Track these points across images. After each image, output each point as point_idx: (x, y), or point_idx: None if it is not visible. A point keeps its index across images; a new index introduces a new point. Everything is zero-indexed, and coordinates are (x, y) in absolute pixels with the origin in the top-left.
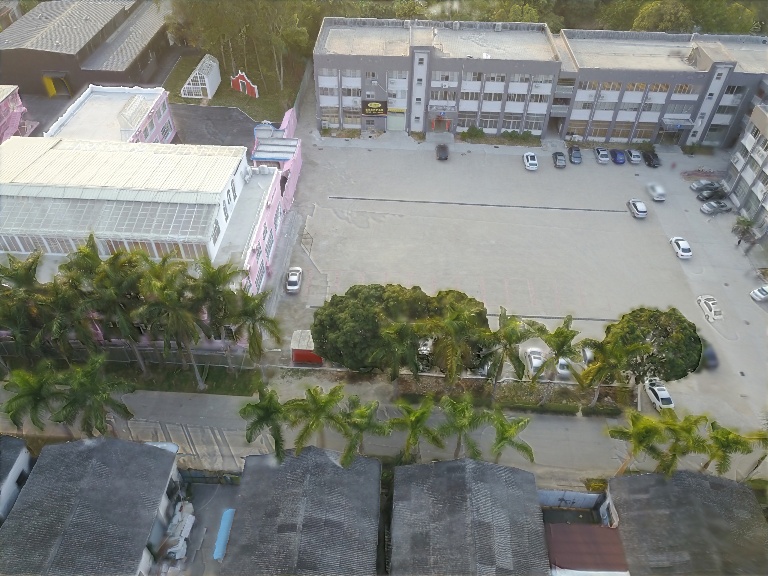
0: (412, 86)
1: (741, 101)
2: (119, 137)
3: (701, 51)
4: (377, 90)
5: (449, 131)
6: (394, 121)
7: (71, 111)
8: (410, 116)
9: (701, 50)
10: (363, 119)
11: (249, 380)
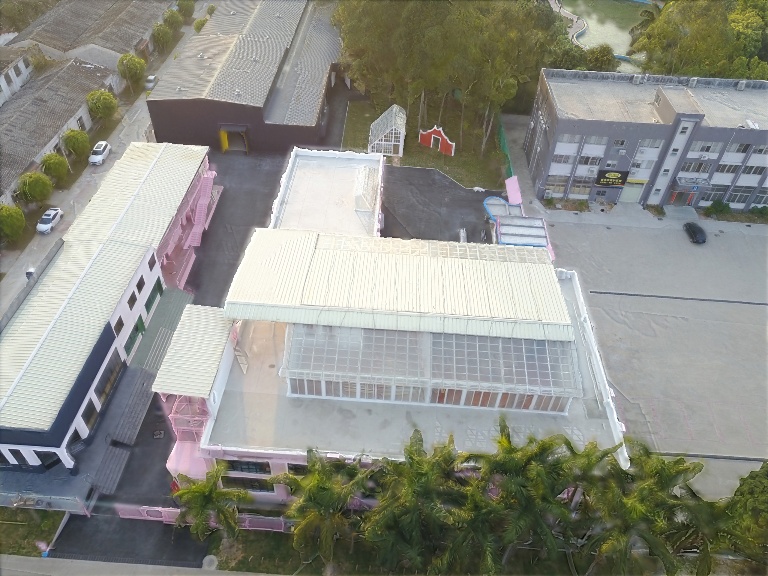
0: (665, 157)
1: None
2: (358, 221)
3: None
4: (621, 159)
5: (689, 204)
6: (628, 192)
7: (285, 183)
8: (651, 188)
9: None
10: (594, 189)
11: (630, 575)
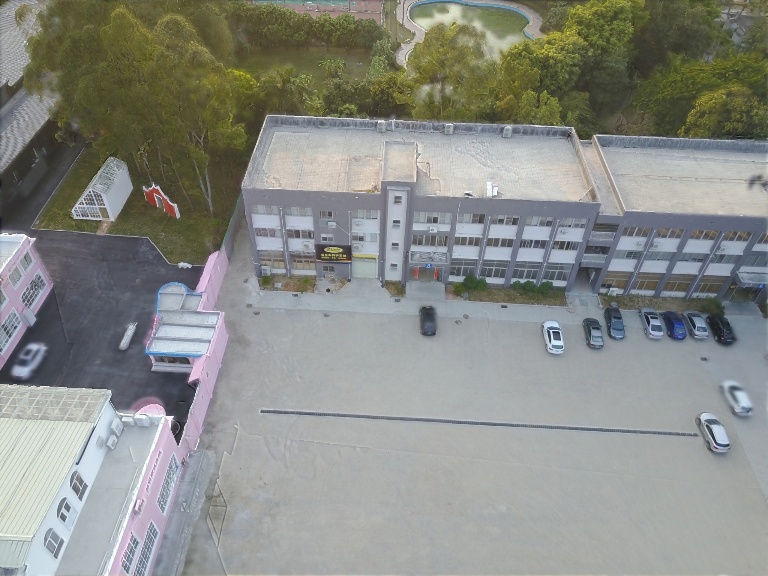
0: (386, 229)
1: None
2: None
3: None
4: (336, 232)
5: (438, 280)
6: (362, 267)
7: None
8: (384, 264)
9: None
10: (318, 265)
11: None
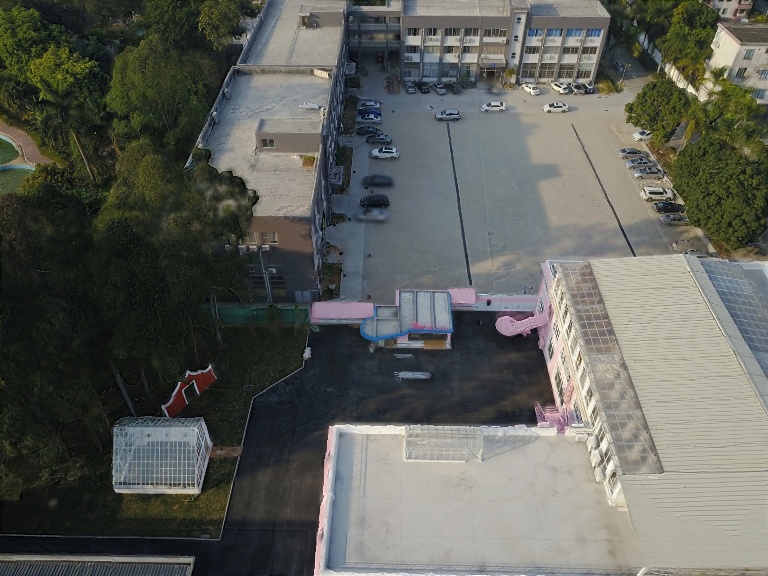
0: (327, 173)
1: (347, 32)
2: (506, 455)
3: (317, 13)
4: None
5: None
6: None
7: None
8: None
9: (316, 13)
10: None
11: None
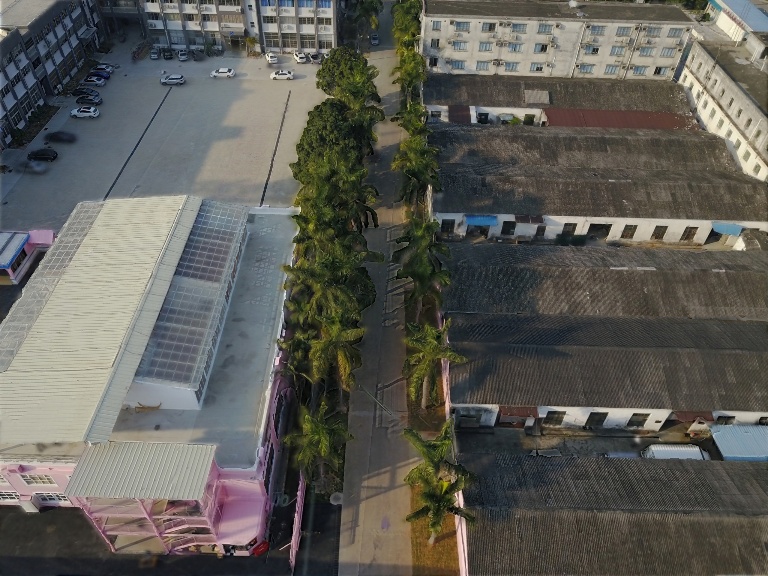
0: None
1: None
2: None
3: None
4: None
5: (2, 149)
6: None
7: None
8: None
9: None
10: None
11: None
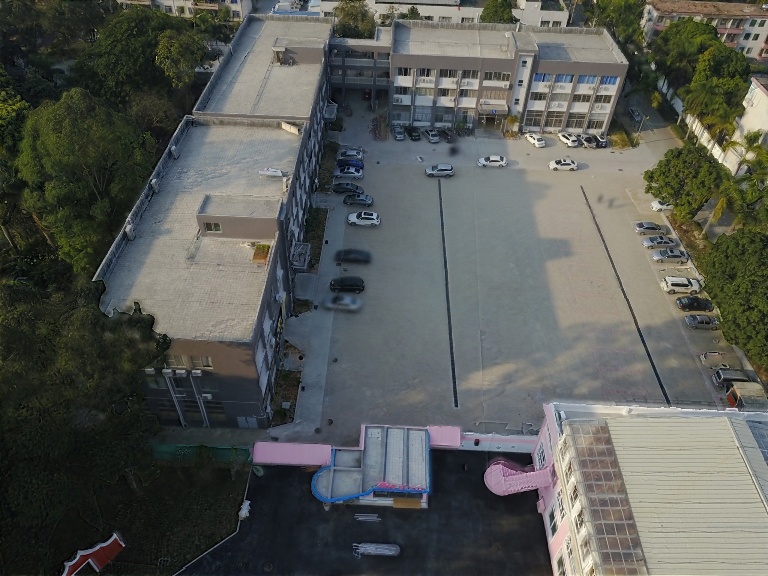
0: (287, 261)
1: None
2: None
3: (294, 49)
4: None
5: None
6: None
7: None
8: (290, 296)
9: (293, 48)
10: (276, 354)
11: None
